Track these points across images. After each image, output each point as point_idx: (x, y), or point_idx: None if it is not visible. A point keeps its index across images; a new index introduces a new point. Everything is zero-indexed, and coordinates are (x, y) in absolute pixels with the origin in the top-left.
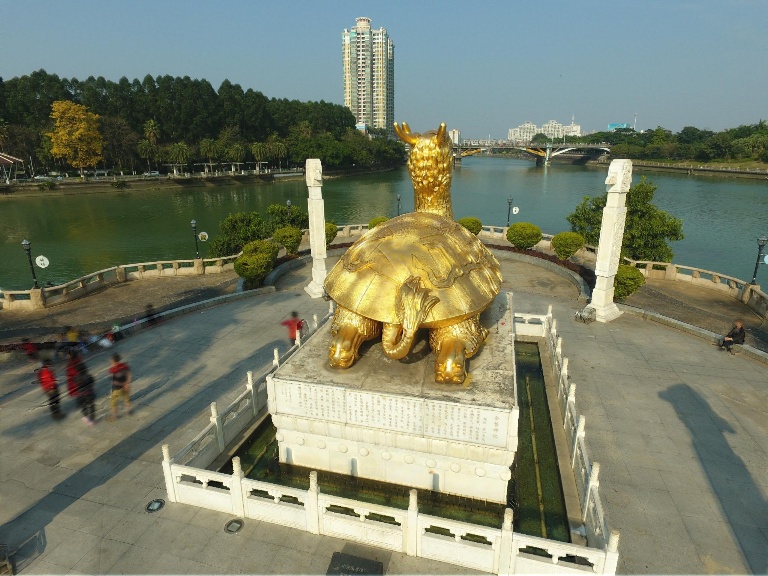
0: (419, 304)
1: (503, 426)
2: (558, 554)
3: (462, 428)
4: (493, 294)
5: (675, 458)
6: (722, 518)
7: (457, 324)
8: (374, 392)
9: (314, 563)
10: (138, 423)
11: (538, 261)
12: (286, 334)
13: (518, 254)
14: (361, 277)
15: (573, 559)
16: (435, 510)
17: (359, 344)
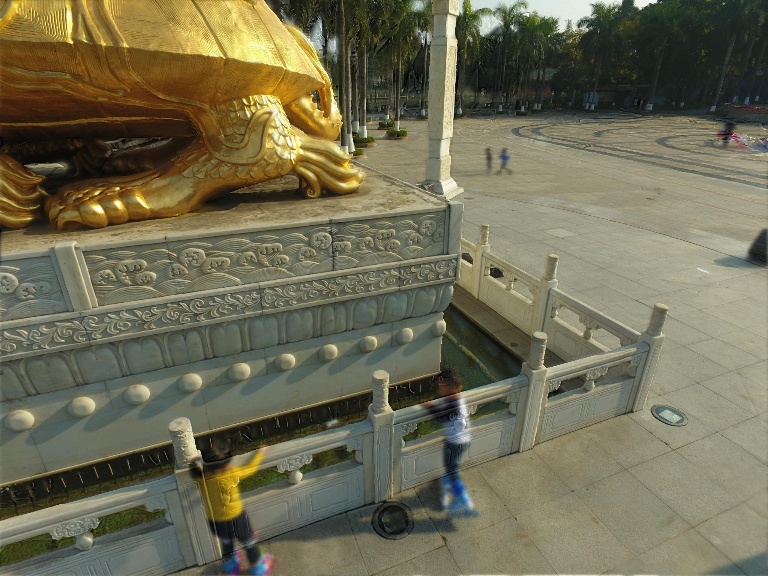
0: None
1: None
2: None
3: None
4: None
5: None
6: None
7: None
8: None
9: None
10: None
11: None
12: None
13: None
14: None
15: None
16: None
17: None
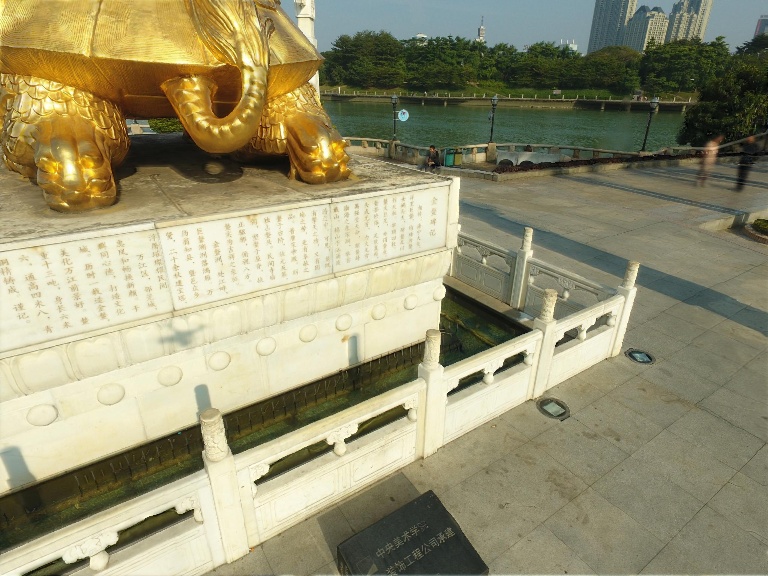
0: (256, 16)
1: (442, 211)
2: (590, 324)
3: (390, 236)
4: None
5: (500, 240)
6: (574, 261)
7: (298, 88)
8: (229, 212)
9: None
10: None
11: None
12: None
13: None
14: None
15: None
16: (366, 392)
17: (108, 157)
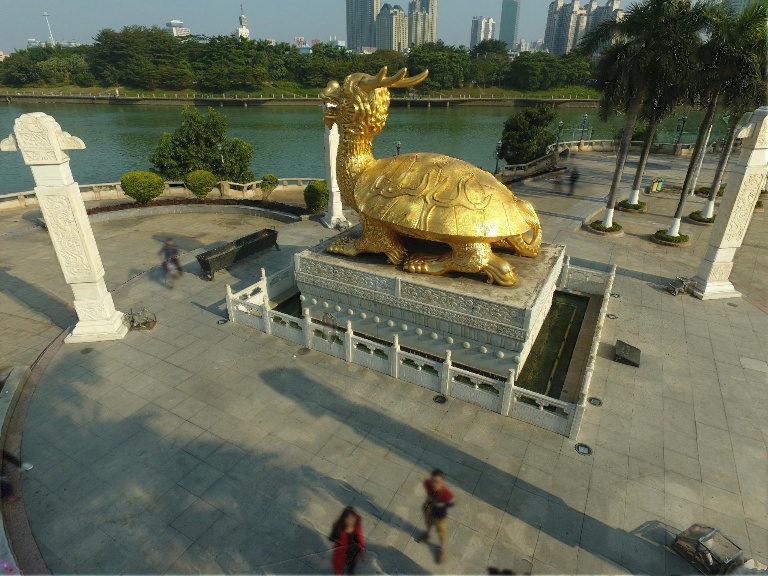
0: None
1: None
2: None
3: None
4: None
5: None
6: None
7: None
8: None
9: (616, 368)
10: (443, 490)
11: (182, 208)
12: (245, 367)
13: (151, 208)
14: (497, 209)
15: (587, 297)
16: None
17: None
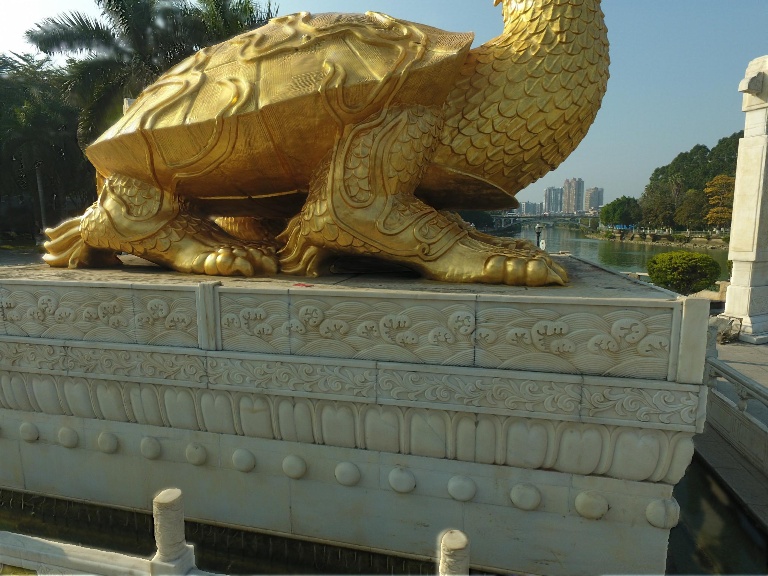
0: None
1: None
2: None
3: None
4: (130, 128)
5: None
6: None
7: None
8: None
9: None
10: None
11: None
12: None
13: None
14: None
15: None
16: None
17: None
